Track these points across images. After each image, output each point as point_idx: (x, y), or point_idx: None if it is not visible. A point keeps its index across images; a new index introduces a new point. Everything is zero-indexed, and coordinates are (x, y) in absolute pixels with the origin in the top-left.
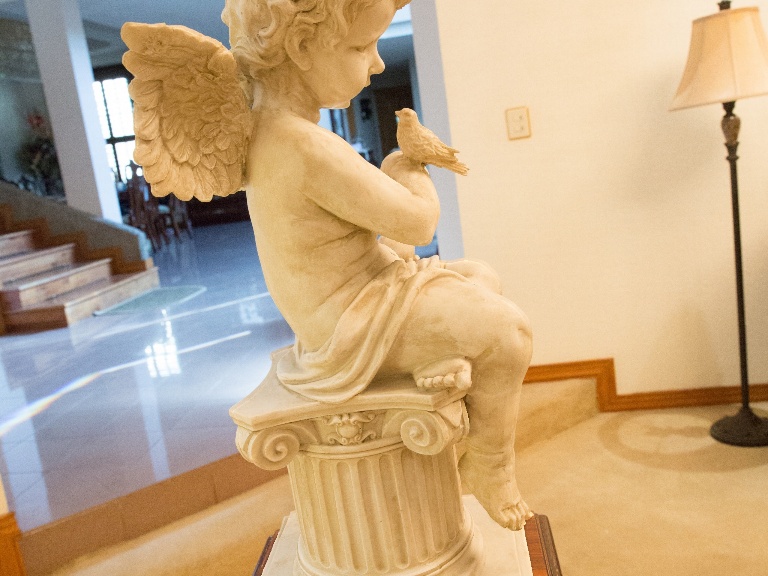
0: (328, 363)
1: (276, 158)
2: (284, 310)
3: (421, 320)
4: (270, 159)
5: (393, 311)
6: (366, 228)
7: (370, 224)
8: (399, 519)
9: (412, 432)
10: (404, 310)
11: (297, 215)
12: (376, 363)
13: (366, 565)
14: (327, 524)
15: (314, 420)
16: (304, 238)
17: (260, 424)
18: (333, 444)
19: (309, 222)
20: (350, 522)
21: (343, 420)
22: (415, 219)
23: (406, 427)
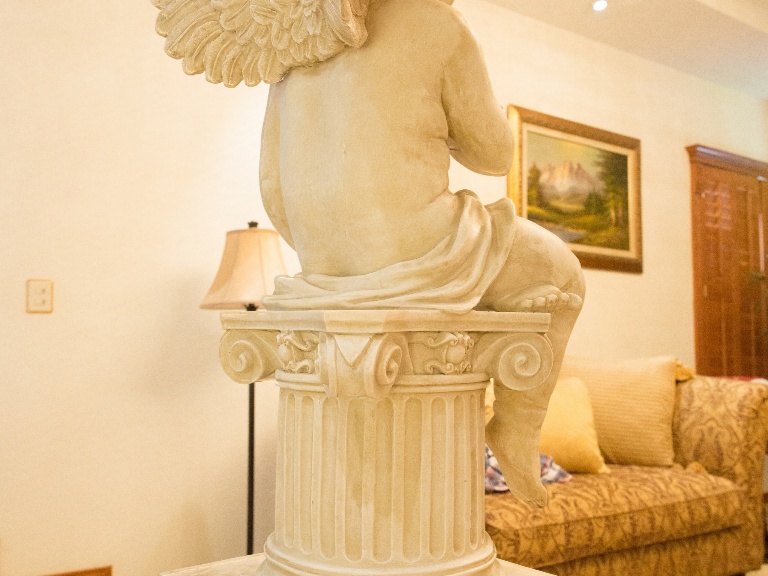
0: (447, 266)
1: (427, 21)
2: (372, 208)
3: (525, 238)
4: (417, 21)
5: (499, 225)
6: (471, 135)
7: (483, 129)
8: (474, 482)
9: (521, 358)
10: (515, 223)
11: (429, 92)
12: (493, 274)
13: (444, 545)
14: (401, 491)
15: (412, 342)
16: (429, 121)
17: (389, 323)
18: (432, 374)
19: (437, 105)
20: (433, 484)
21: (459, 337)
22: (512, 140)
23: (508, 355)
